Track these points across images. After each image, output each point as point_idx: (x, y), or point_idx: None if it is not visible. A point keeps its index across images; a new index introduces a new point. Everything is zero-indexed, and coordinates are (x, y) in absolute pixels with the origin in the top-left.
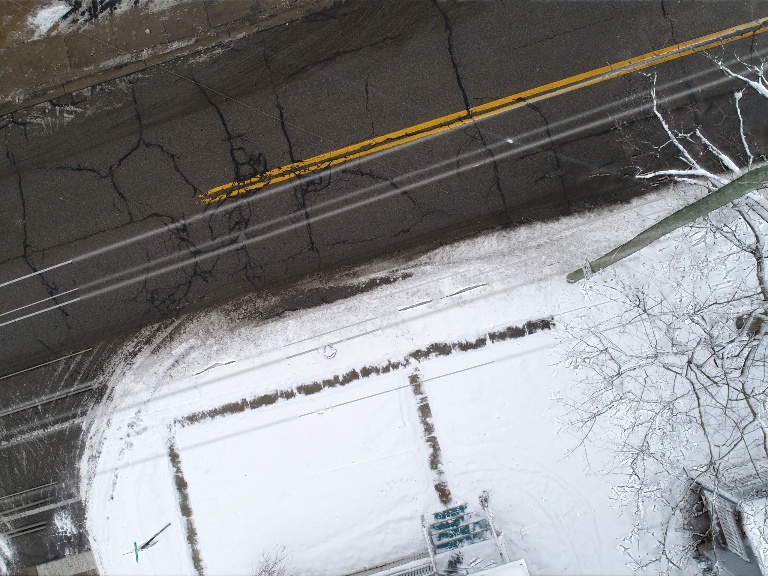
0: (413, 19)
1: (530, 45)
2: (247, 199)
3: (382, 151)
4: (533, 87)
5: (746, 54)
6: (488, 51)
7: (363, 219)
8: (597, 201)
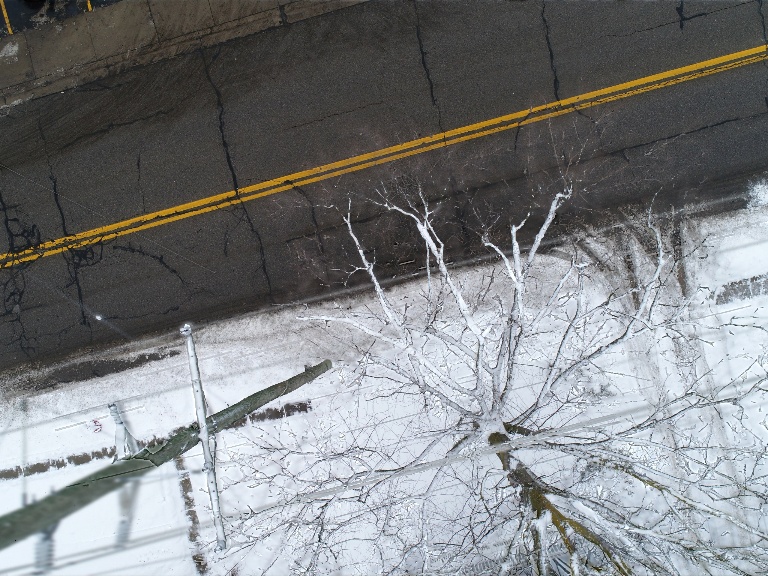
0: (186, 93)
1: (300, 126)
2: (21, 271)
3: (152, 228)
4: (301, 170)
5: (510, 146)
6: (258, 131)
7: (133, 296)
8: (359, 288)
